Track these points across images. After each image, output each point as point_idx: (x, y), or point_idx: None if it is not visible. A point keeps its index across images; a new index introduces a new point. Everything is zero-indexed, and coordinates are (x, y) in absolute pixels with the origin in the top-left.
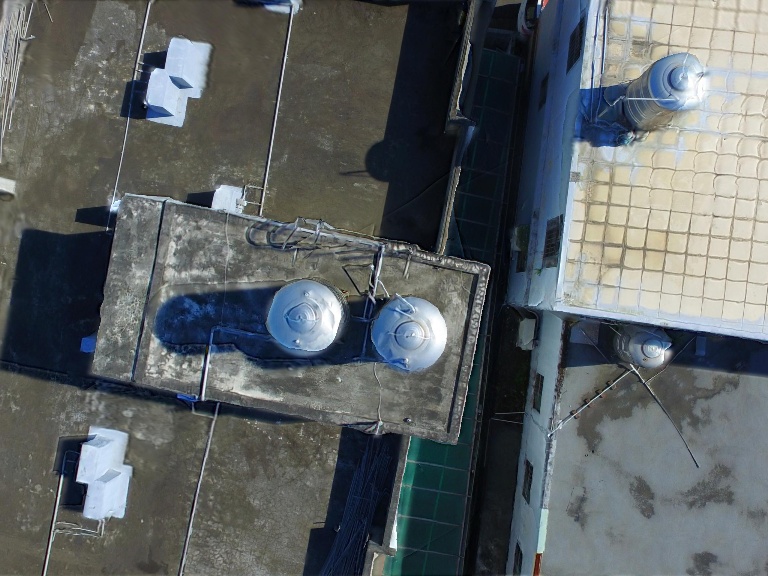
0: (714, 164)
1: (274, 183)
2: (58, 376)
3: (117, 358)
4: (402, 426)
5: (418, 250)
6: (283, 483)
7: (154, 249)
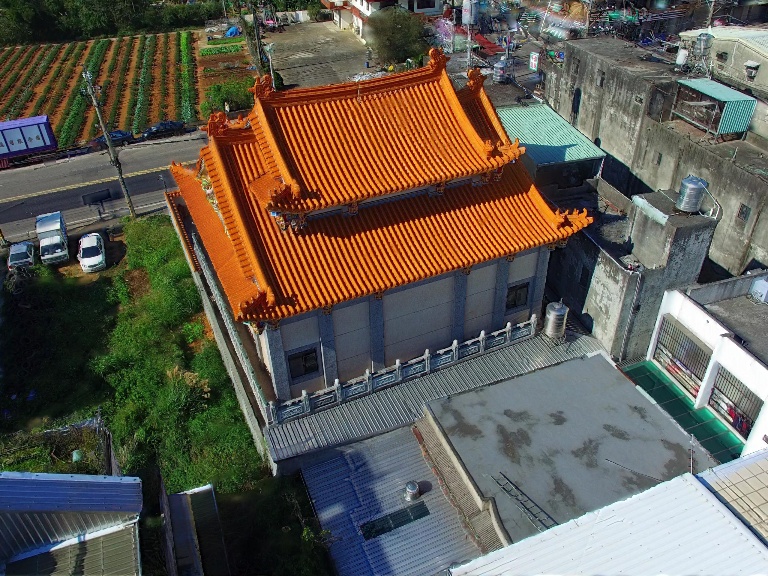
0: None
1: None
2: None
3: None
4: None
5: None
6: None
7: None
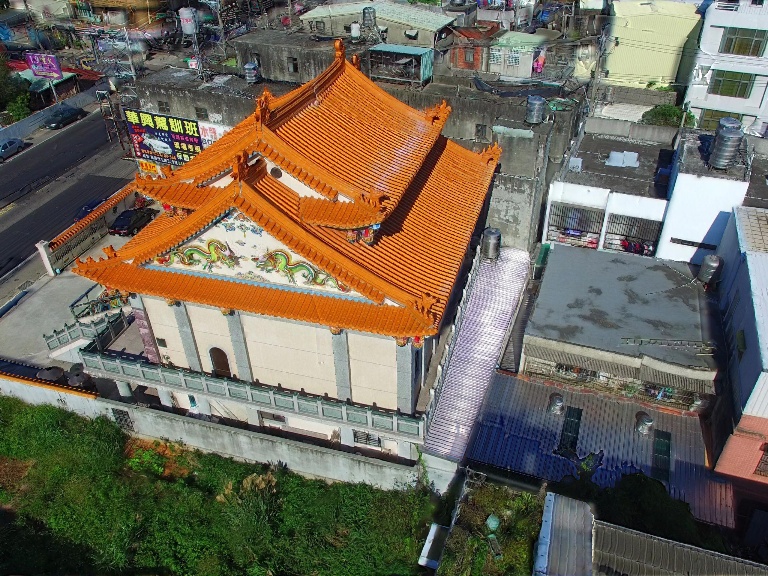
0: None
1: (752, 199)
2: (657, 158)
3: None
4: None
5: None
6: (625, 191)
7: None
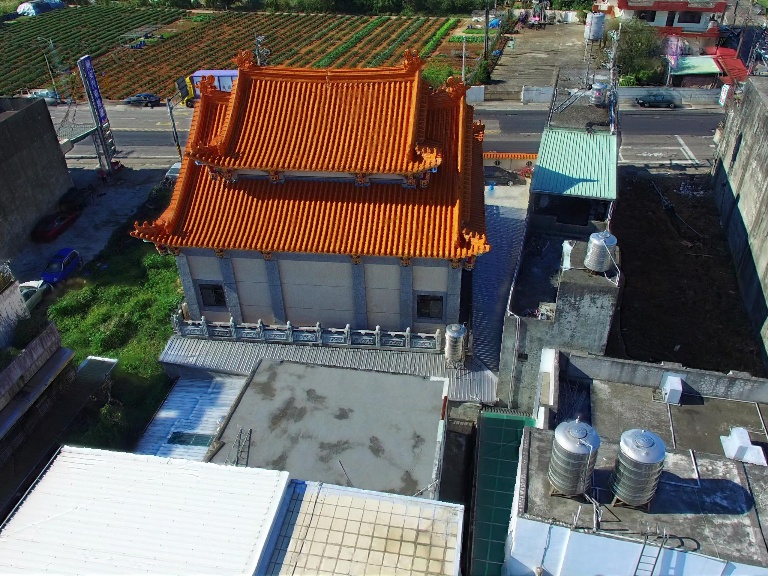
0: None
1: None
2: None
3: (760, 474)
4: None
5: (570, 528)
6: None
7: (767, 539)
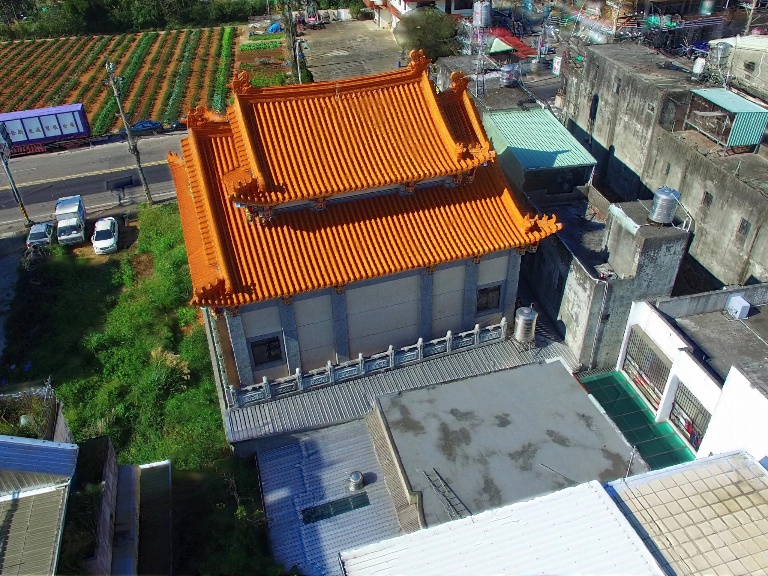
0: (746, 566)
1: None
2: None
3: None
4: (763, 363)
5: None
6: None
7: None
